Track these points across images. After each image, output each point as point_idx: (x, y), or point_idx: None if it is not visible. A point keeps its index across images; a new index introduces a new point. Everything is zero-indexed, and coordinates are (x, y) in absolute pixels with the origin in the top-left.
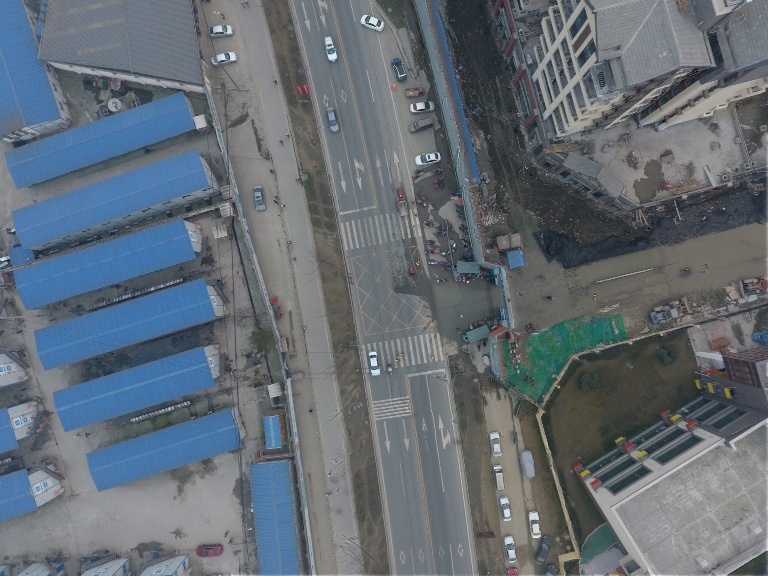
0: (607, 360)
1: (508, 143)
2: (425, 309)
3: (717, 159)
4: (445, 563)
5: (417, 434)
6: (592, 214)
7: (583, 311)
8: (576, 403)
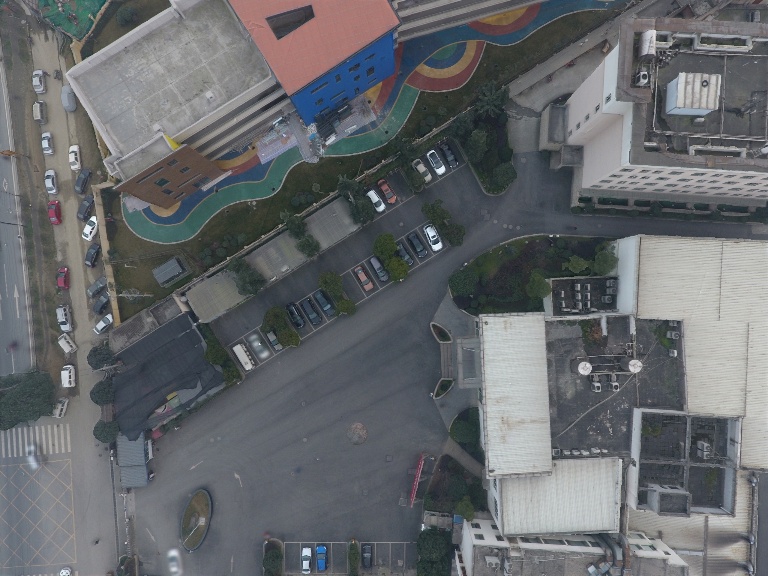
0: None
1: None
2: None
3: None
4: None
5: None
6: None
7: None
8: None
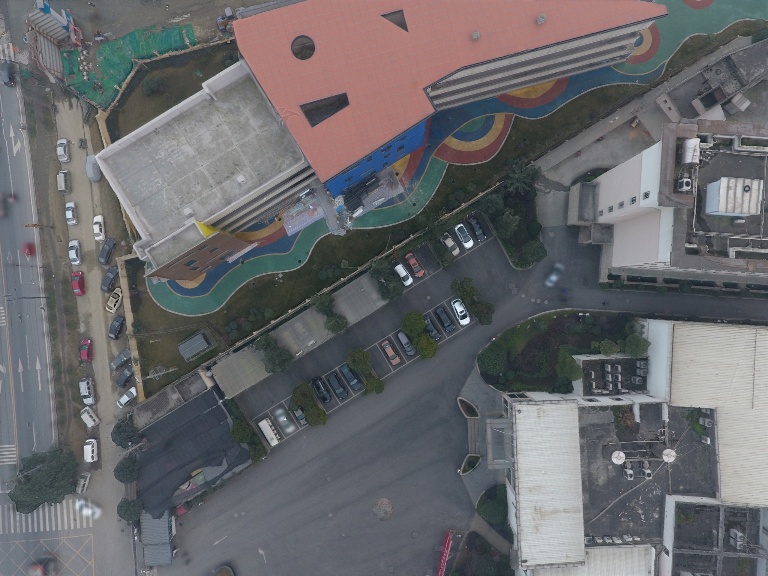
0: (176, 68)
1: None
2: None
3: None
4: (13, 268)
5: None
6: None
7: (154, 21)
8: (143, 109)
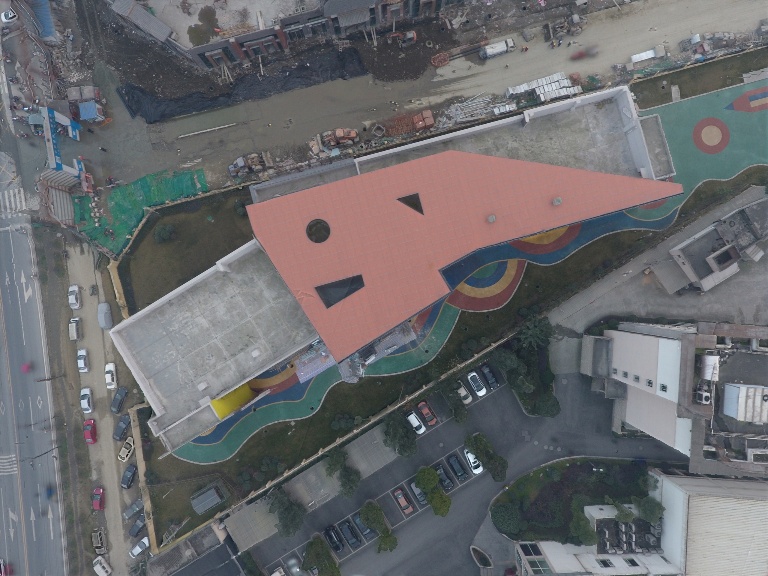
0: (187, 214)
1: (96, 1)
2: (10, 165)
3: (271, 5)
4: (24, 415)
5: (1, 288)
6: (177, 70)
7: (165, 166)
8: (155, 256)
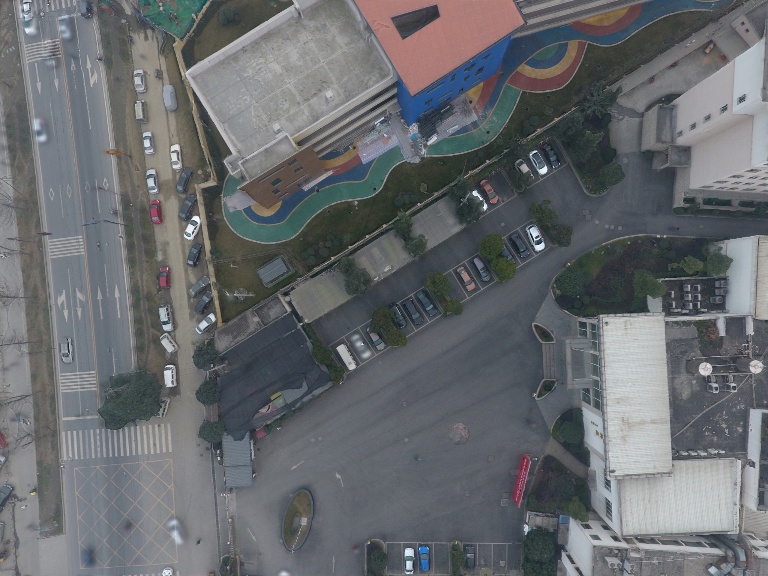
0: None
1: None
2: None
3: None
4: (91, 197)
5: (66, 74)
6: None
7: None
8: (219, 39)
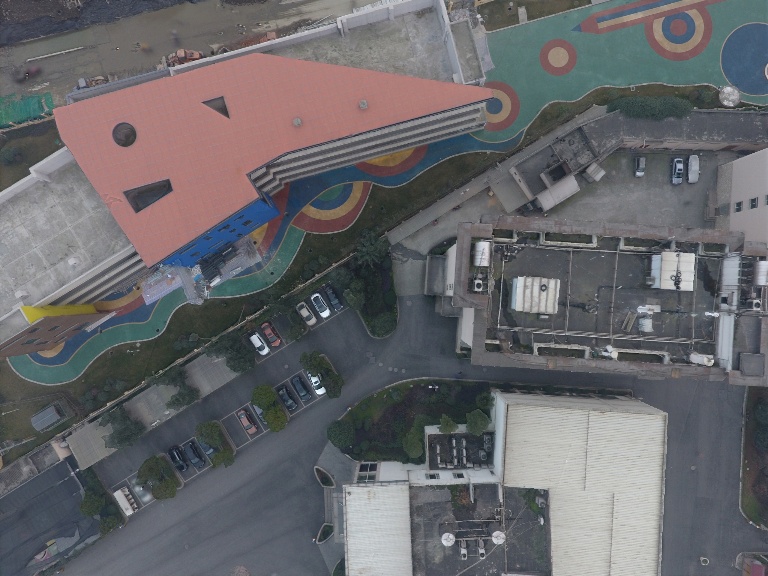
0: (34, 137)
1: None
2: None
3: None
4: None
5: None
6: None
7: (13, 89)
8: (2, 179)
